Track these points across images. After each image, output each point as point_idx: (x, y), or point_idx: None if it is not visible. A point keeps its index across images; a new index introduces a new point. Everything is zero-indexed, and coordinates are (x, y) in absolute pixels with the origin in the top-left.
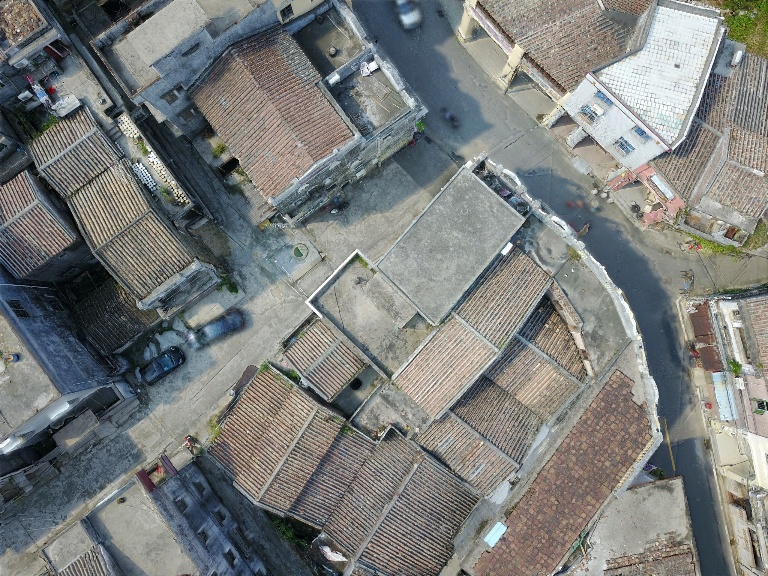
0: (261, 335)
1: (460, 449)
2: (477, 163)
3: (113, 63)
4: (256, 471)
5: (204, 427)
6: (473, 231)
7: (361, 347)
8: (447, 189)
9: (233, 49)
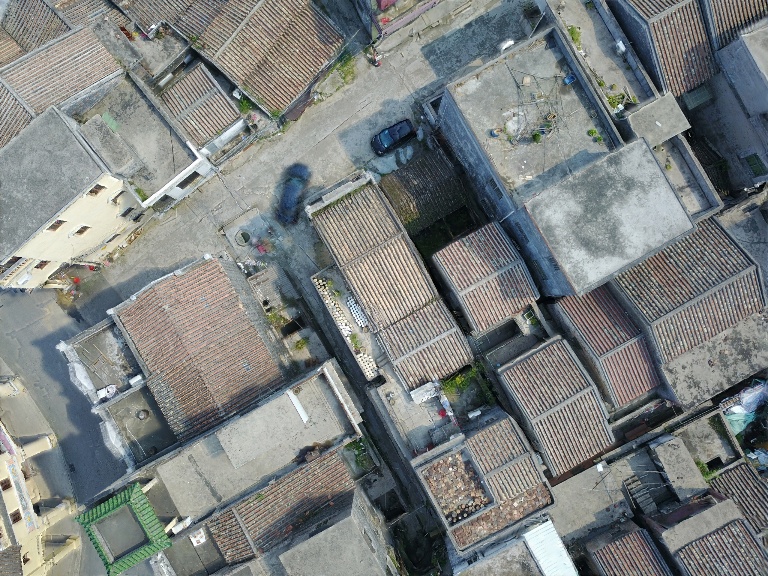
0: (293, 158)
1: (83, 5)
2: (3, 275)
3: (346, 416)
4: (285, 5)
5: (361, 73)
6: (1, 196)
7: (155, 110)
8: (22, 243)
9: (222, 417)
